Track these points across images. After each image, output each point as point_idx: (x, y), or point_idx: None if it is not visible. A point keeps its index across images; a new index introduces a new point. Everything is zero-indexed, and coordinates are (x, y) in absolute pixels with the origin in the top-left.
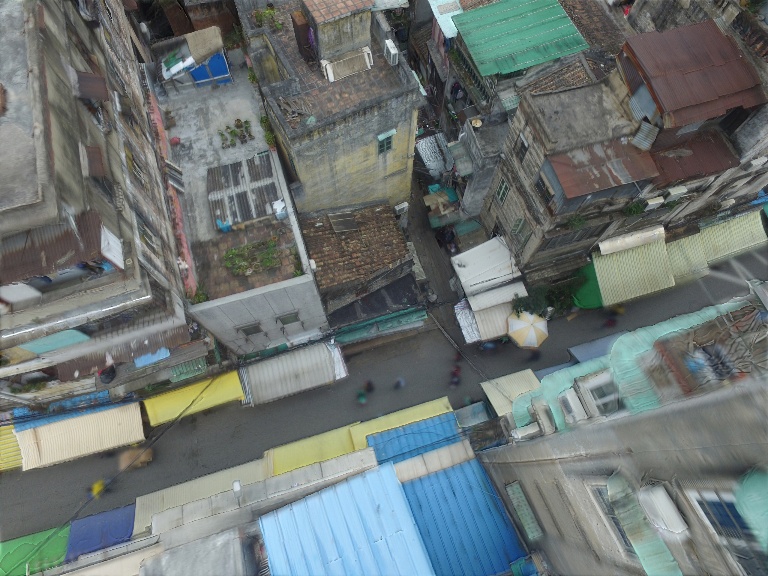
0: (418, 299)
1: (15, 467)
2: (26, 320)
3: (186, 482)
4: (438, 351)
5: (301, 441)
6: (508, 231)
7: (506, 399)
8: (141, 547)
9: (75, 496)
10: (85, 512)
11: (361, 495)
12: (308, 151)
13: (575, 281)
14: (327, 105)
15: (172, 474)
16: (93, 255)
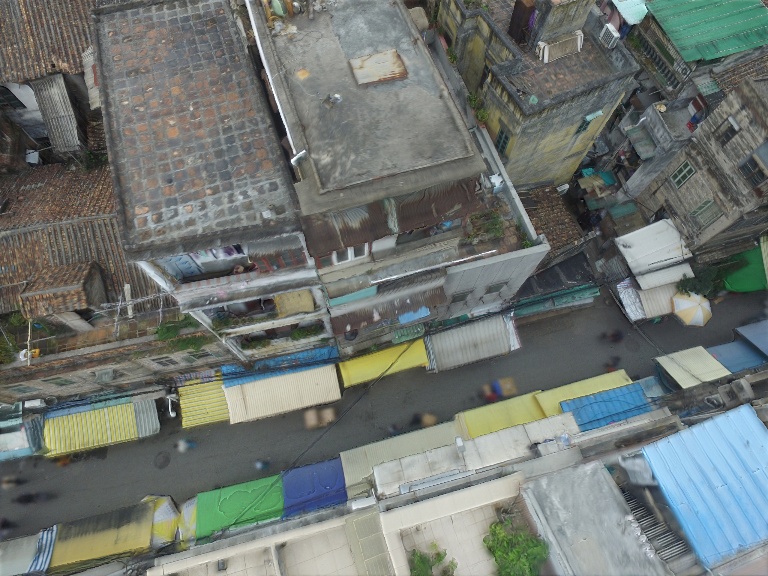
0: (595, 276)
1: (219, 421)
2: (363, 270)
3: (384, 440)
4: (592, 329)
5: (488, 406)
6: (681, 214)
7: (687, 373)
8: (482, 478)
9: (263, 452)
10: (274, 467)
11: (729, 432)
12: (531, 128)
13: (735, 265)
14: (545, 85)
15: (351, 435)
16: (478, 208)
